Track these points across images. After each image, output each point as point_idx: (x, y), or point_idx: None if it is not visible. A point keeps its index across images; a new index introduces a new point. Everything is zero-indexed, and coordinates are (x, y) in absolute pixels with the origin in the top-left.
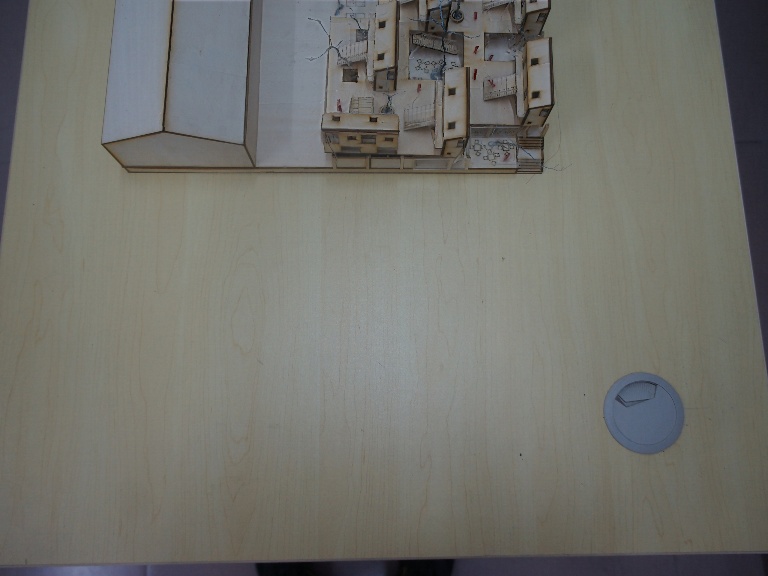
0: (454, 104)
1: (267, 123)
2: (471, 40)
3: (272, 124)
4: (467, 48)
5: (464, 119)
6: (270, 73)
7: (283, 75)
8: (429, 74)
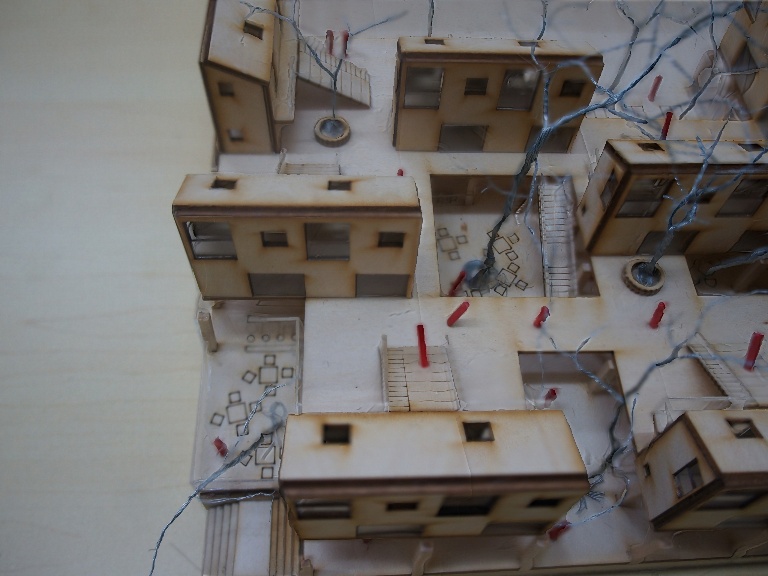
0: (295, 187)
1: (331, 0)
2: (579, 315)
3: (329, 6)
4: (550, 305)
5: (233, 200)
6: (439, 2)
7: (437, 18)
8: (481, 258)
